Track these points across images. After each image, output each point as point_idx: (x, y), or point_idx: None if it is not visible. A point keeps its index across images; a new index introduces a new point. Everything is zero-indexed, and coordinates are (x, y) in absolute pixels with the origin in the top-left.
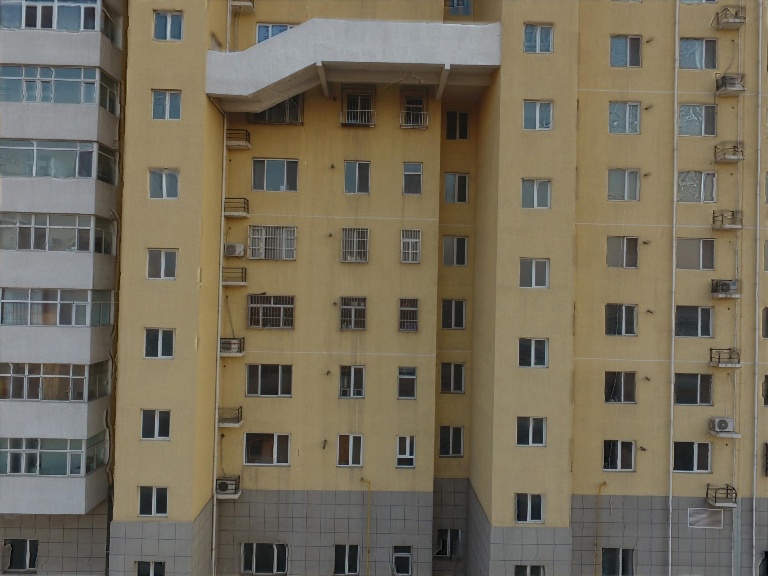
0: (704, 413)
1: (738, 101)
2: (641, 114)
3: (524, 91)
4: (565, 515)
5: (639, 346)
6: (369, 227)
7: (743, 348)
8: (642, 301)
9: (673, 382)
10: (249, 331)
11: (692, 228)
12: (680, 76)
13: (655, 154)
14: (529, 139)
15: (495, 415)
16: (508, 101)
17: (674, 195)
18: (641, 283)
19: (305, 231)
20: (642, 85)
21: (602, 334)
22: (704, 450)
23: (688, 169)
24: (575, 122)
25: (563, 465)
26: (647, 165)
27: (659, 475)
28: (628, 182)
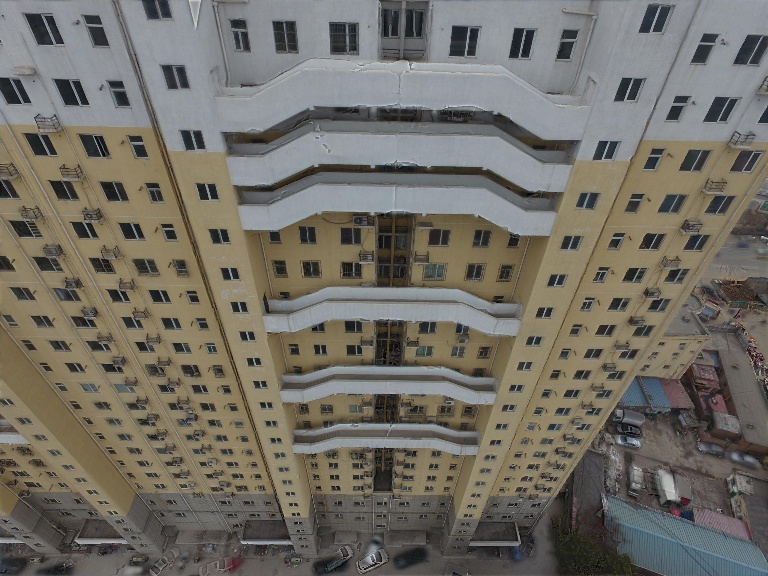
0: None
1: (160, 419)
2: (120, 422)
3: None
4: (124, 514)
5: None
6: (27, 447)
7: None
8: None
9: None
10: (3, 466)
11: None
12: None
13: None
14: (56, 458)
15: None
16: (41, 451)
17: None
18: None
19: (2, 448)
20: None
21: (137, 467)
22: None
23: None
24: (70, 455)
25: None
26: (131, 433)
27: (175, 490)
28: None
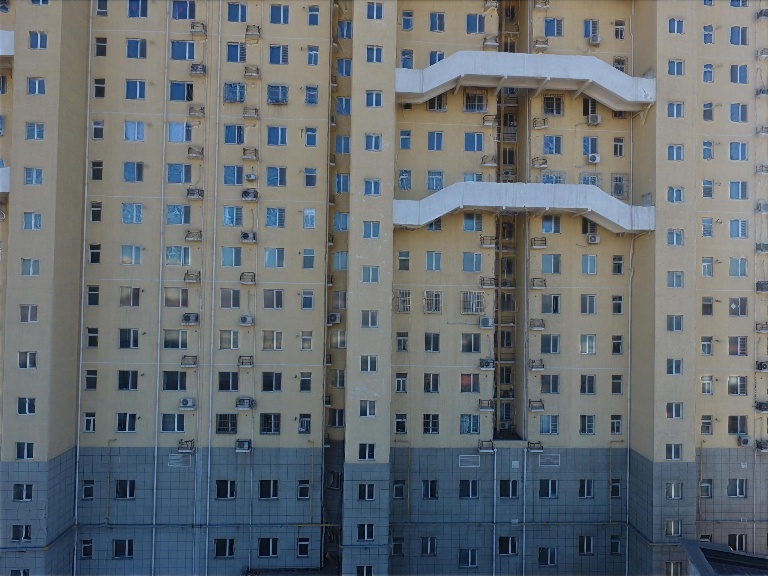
0: (179, 396)
1: (202, 203)
2: (142, 211)
3: (24, 207)
4: (45, 454)
5: (139, 355)
6: None
7: (205, 355)
8: (141, 327)
9: (159, 377)
10: None
11: (173, 281)
12: (167, 187)
13: (151, 236)
14: (26, 235)
15: (4, 397)
16: (13, 213)
17: (160, 261)
18: (140, 316)
19: None
20: (142, 193)
21: (115, 348)
22: (181, 418)
23: (171, 245)
24: (54, 225)
25: (45, 425)
26: (146, 243)
27: (150, 434)
28: (135, 253)
